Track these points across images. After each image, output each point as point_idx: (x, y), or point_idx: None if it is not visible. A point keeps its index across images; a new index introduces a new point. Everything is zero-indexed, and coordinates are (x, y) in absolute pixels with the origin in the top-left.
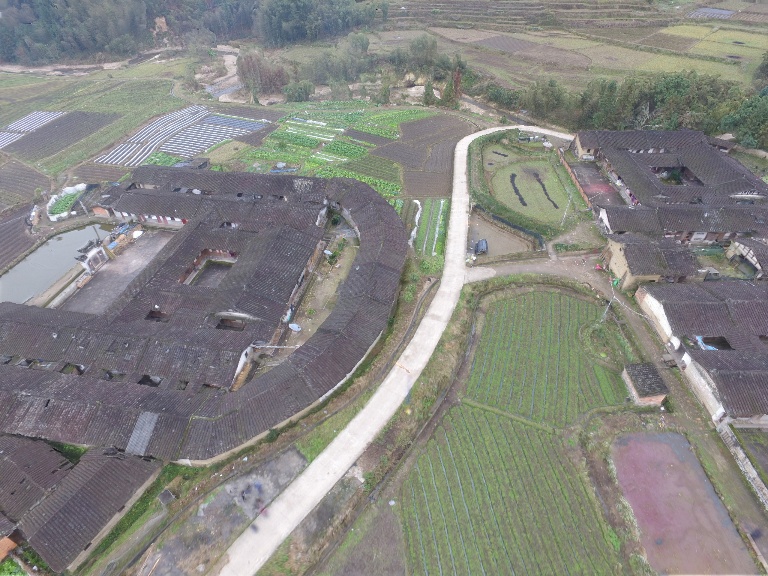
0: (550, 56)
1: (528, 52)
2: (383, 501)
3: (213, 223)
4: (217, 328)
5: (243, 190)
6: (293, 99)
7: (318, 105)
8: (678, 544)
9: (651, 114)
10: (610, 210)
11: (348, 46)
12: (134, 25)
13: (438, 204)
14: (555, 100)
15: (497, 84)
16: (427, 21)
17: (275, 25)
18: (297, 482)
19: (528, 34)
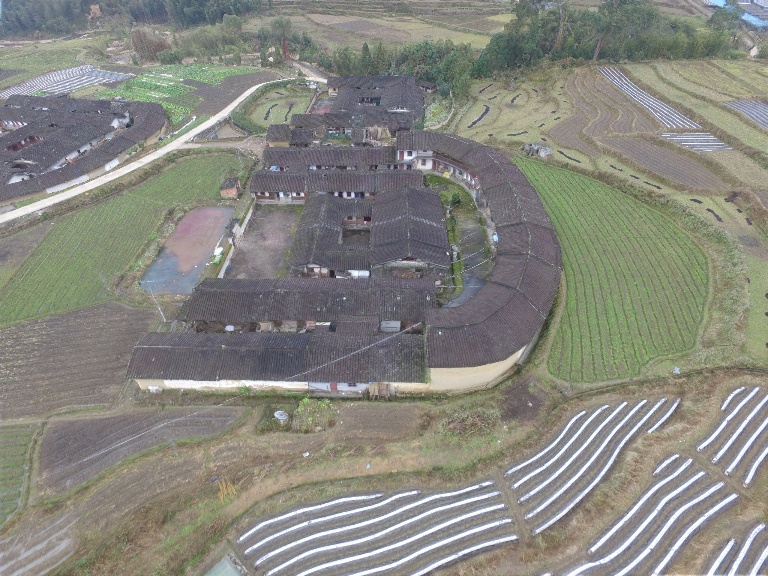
0: (382, 34)
1: (368, 31)
2: (47, 222)
3: (43, 123)
4: (11, 167)
5: (77, 108)
6: (165, 62)
7: (181, 66)
8: (186, 239)
9: (399, 68)
10: (294, 114)
11: (222, 25)
12: (70, 10)
13: (206, 118)
14: (348, 61)
15: (326, 53)
16: (307, 9)
17: (179, 10)
18: (5, 213)
19: (382, 19)
